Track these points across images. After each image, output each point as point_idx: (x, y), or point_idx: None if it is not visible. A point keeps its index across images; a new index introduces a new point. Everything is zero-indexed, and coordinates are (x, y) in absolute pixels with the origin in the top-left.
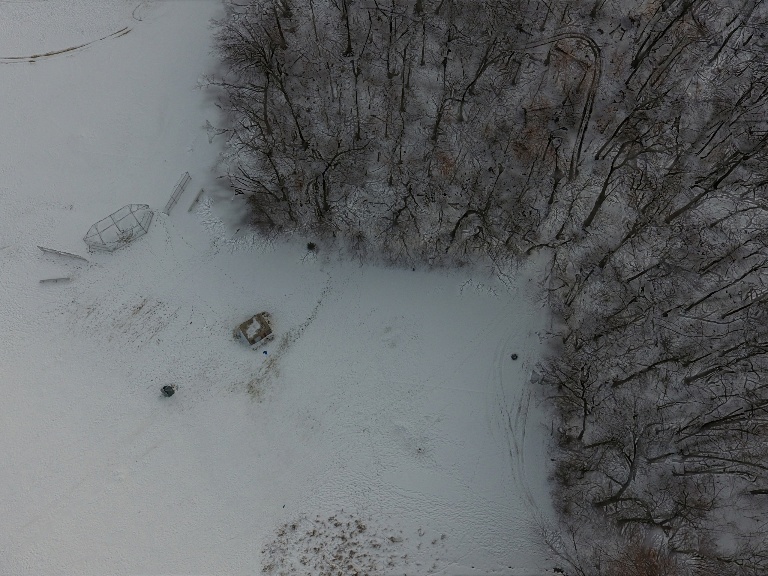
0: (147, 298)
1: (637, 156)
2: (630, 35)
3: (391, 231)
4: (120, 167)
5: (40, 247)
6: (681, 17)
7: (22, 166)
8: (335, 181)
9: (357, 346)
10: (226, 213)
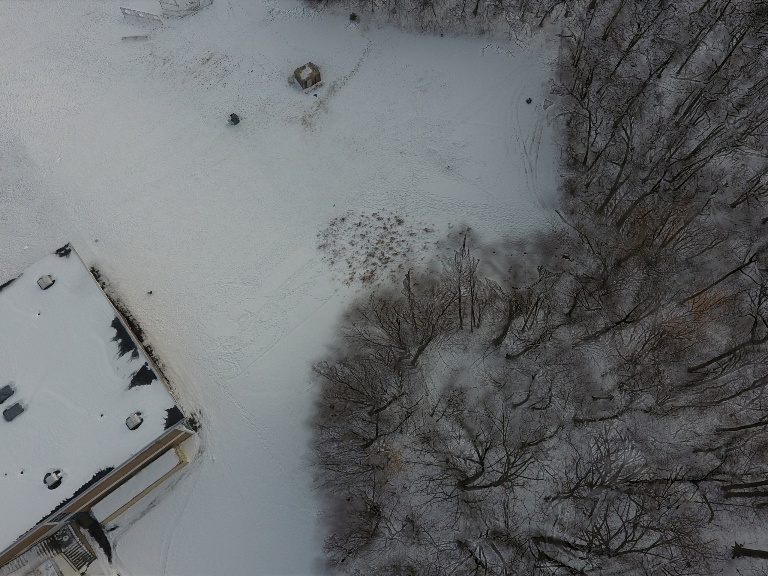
0: (214, 52)
1: None
2: None
3: (422, 9)
4: None
5: (123, 8)
6: None
7: None
8: None
9: (394, 91)
10: None
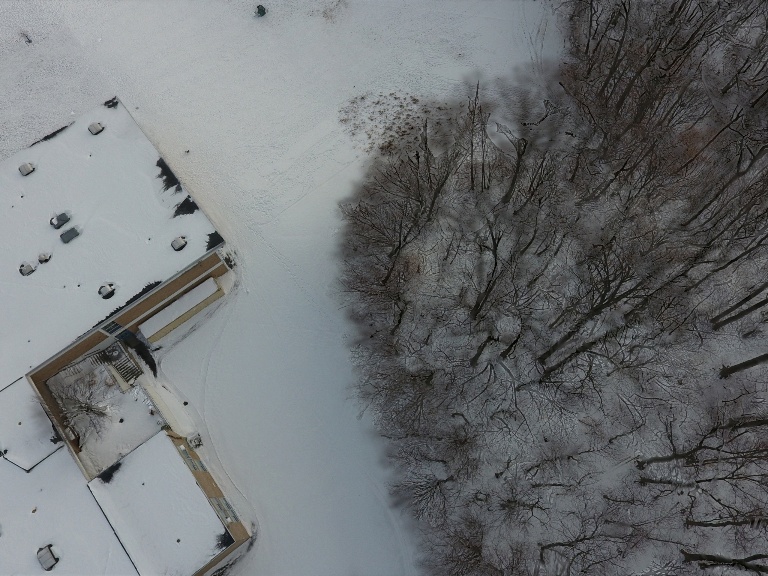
0: None
1: None
2: None
3: None
4: None
5: None
6: None
7: None
8: None
9: None
10: None
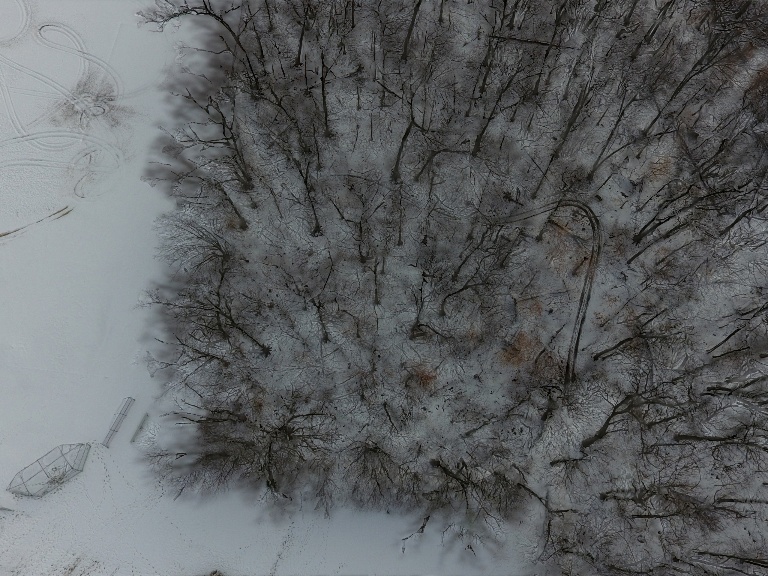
0: (80, 556)
1: (643, 405)
2: (632, 203)
3: (363, 459)
4: (54, 386)
5: None
6: (690, 209)
7: None
8: (300, 395)
9: None
10: (174, 442)
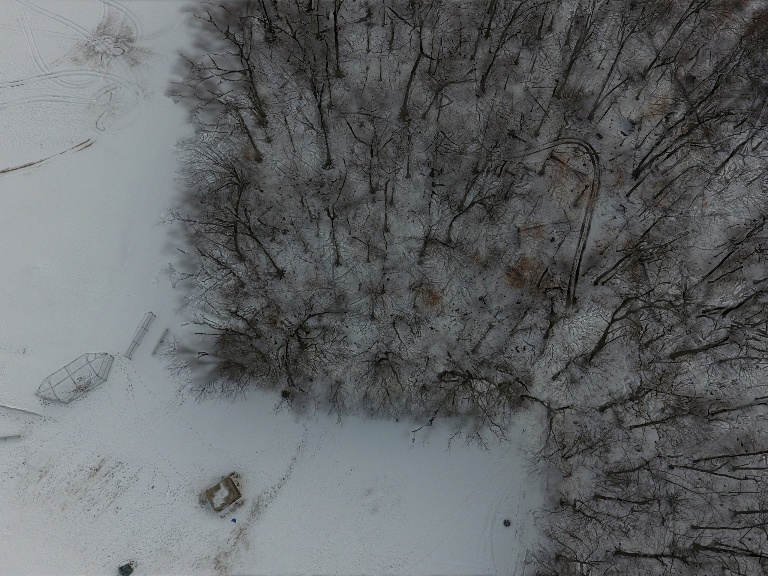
0: (105, 458)
1: (640, 310)
2: (631, 140)
3: (373, 373)
4: (78, 303)
5: None
6: (686, 137)
7: None
8: None
9: (335, 512)
10: (193, 355)
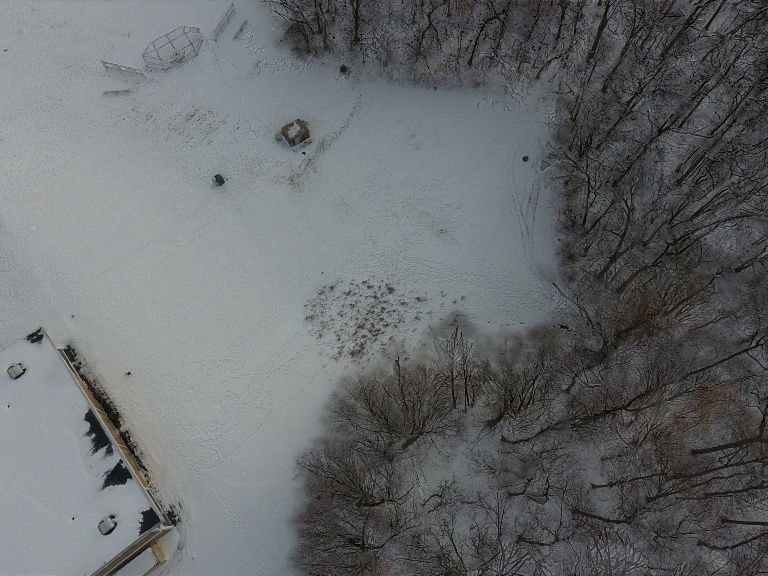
0: (199, 108)
1: None
2: None
3: (415, 59)
4: (172, 3)
5: (104, 62)
6: None
7: (84, 1)
8: (364, 19)
9: (385, 149)
10: (267, 41)
